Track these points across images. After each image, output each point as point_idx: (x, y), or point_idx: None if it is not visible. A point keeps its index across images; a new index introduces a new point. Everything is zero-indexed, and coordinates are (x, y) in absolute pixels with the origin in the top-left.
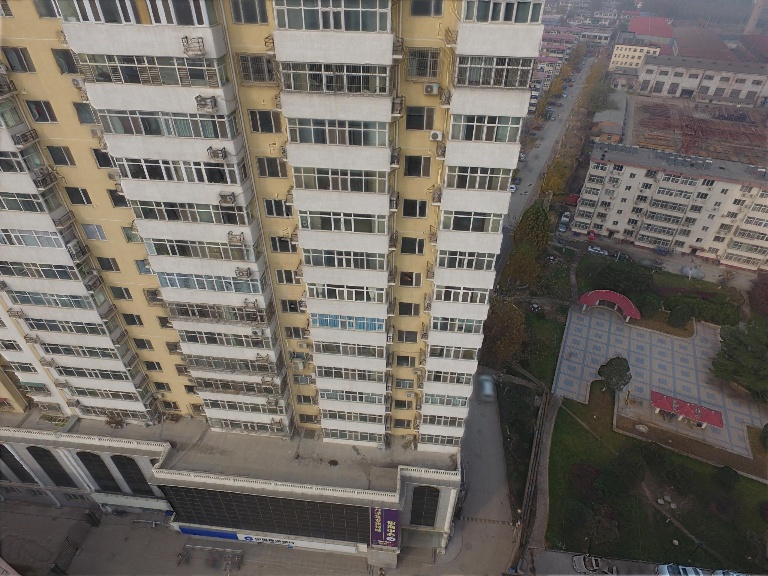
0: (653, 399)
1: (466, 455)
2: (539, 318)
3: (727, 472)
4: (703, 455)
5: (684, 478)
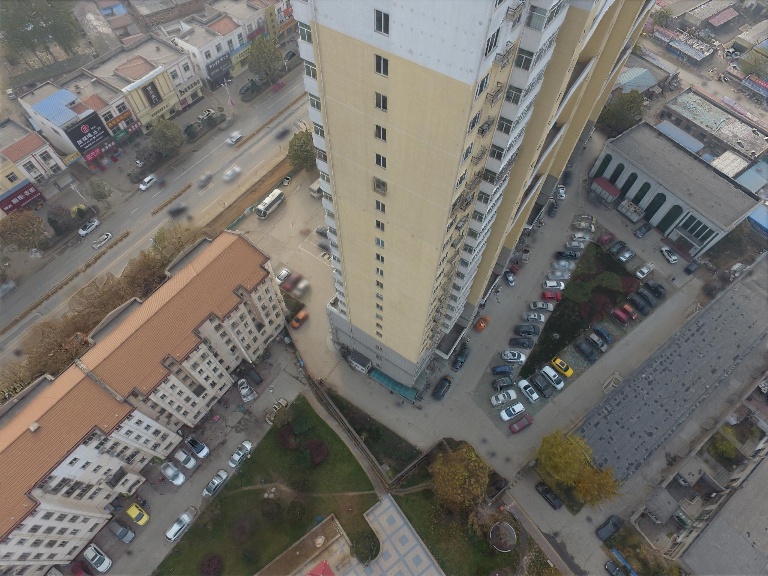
0: (328, 567)
1: (375, 385)
2: (479, 567)
3: (249, 551)
4: (273, 568)
5: (267, 502)
